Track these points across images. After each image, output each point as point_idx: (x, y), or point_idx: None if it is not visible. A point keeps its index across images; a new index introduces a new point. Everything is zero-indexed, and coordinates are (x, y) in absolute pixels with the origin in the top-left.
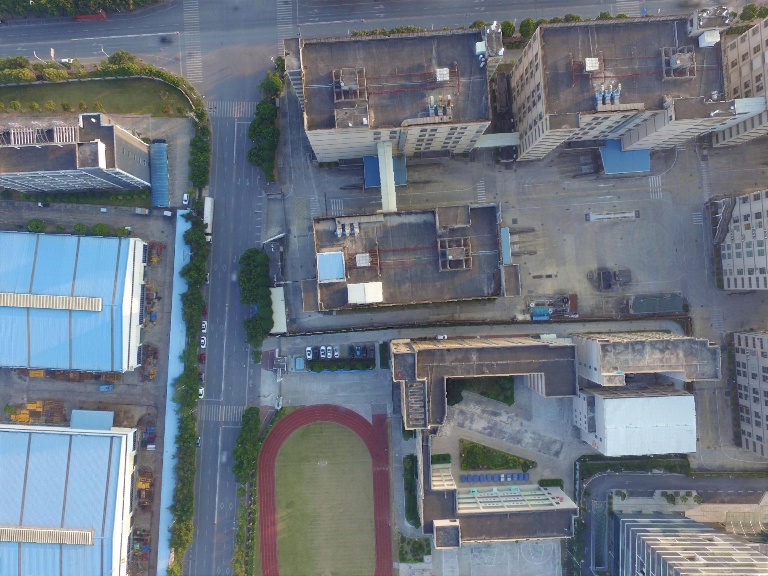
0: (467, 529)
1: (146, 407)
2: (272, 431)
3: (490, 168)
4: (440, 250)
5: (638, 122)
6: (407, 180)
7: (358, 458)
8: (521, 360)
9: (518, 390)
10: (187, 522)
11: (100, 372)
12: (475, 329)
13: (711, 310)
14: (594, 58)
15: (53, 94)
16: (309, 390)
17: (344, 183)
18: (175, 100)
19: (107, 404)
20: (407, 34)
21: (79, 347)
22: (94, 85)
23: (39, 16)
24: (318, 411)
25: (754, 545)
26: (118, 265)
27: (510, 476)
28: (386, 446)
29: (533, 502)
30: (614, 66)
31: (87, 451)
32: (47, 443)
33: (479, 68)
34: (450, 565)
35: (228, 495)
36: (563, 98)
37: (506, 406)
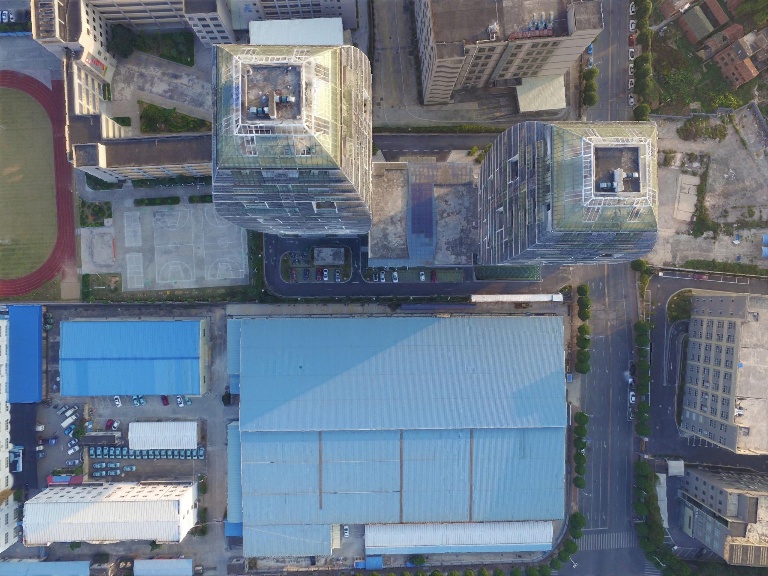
0: (115, 157)
1: None
2: None
3: None
4: None
5: None
6: None
7: (38, 124)
8: None
9: (199, 53)
10: None
11: None
12: None
13: None
14: None
15: None
16: None
17: None
18: None
19: None
20: None
21: None
22: None
23: None
24: None
25: (402, 162)
26: None
27: None
28: None
29: None
30: None
31: None
32: None
33: None
34: (132, 229)
35: None
36: None
37: (187, 68)
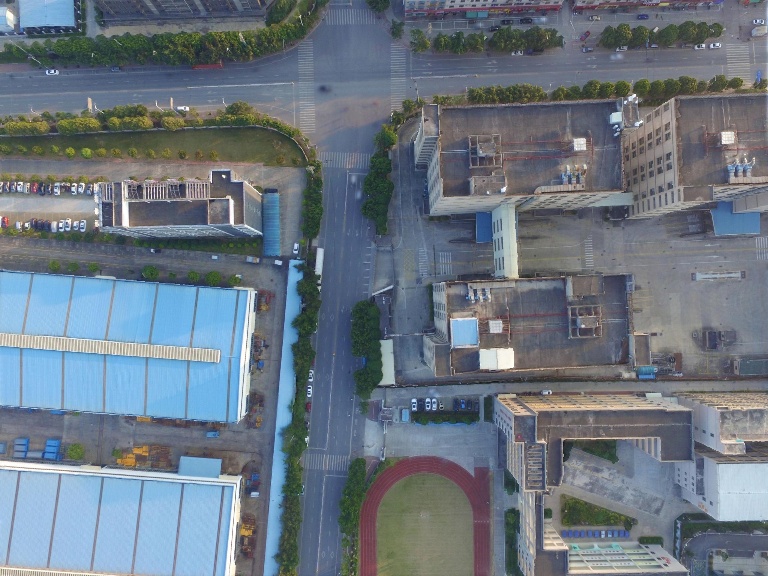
0: None
1: (251, 454)
2: (375, 481)
3: (598, 225)
4: (571, 318)
5: (761, 191)
6: (518, 236)
7: (459, 510)
8: (638, 424)
9: (620, 447)
10: (293, 572)
11: None
12: (579, 385)
13: None
14: (730, 132)
15: (167, 141)
16: (413, 441)
17: (453, 236)
18: (288, 150)
19: (212, 450)
20: (543, 102)
21: (195, 397)
22: (208, 133)
23: (156, 63)
24: (421, 462)
25: None
26: (236, 317)
27: (611, 533)
28: (487, 499)
29: (640, 563)
30: (746, 139)
31: (199, 500)
32: (159, 491)
33: (613, 137)
34: None
35: (330, 544)
36: (695, 169)
37: (608, 463)
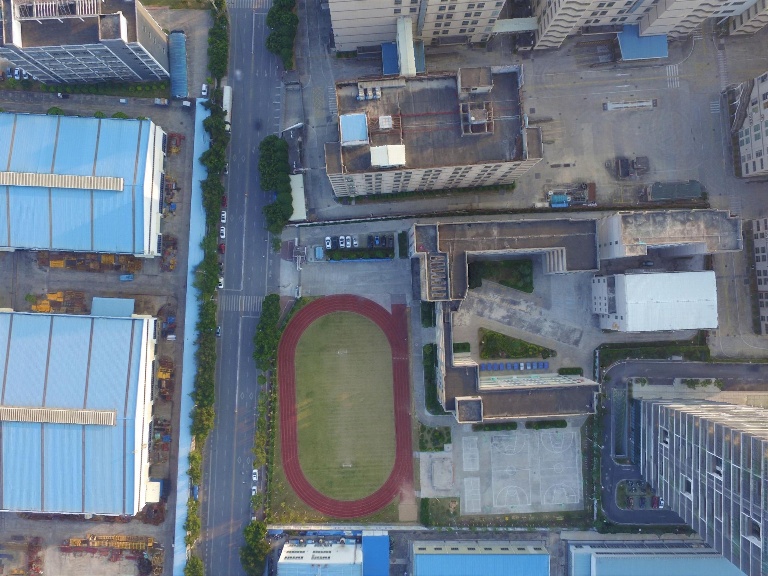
0: (489, 406)
1: (166, 297)
2: (292, 321)
3: (507, 58)
4: (462, 114)
5: None
6: (425, 68)
7: (378, 348)
8: (542, 235)
9: (537, 279)
10: (208, 407)
11: (120, 262)
12: (494, 218)
13: (729, 198)
14: None
15: None
16: (328, 280)
17: (362, 74)
18: None
19: (127, 294)
20: None
21: (101, 228)
22: None
23: None
24: (337, 301)
25: None
26: (139, 146)
27: (530, 364)
28: (405, 336)
29: (554, 382)
30: None
31: (109, 333)
32: (69, 326)
33: None
34: (470, 454)
35: (248, 385)
36: None
37: (525, 295)
